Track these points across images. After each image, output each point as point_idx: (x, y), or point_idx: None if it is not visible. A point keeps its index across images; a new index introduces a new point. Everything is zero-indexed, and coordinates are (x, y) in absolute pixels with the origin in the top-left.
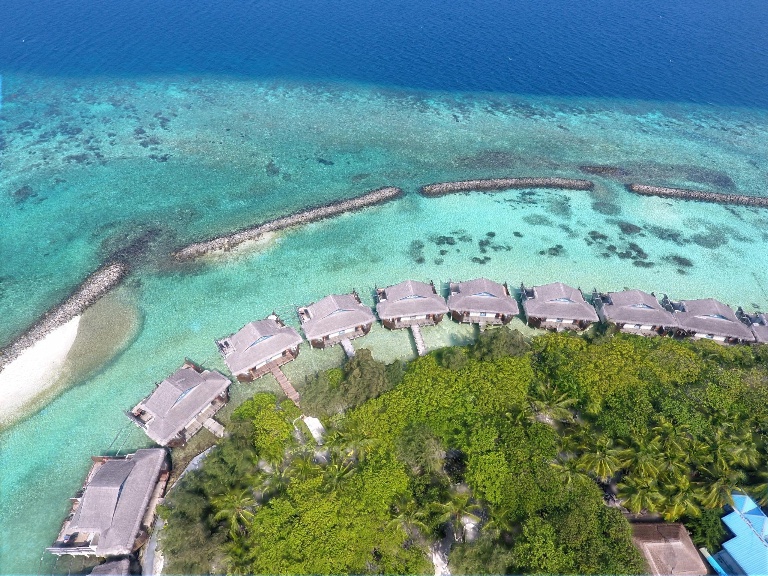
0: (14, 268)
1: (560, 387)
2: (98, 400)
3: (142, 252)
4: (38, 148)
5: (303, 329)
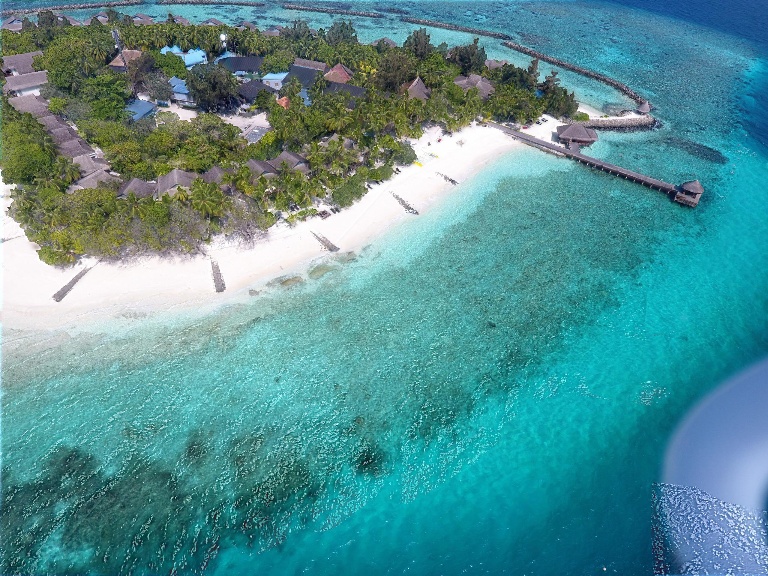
0: None
1: None
2: None
3: None
4: None
5: None
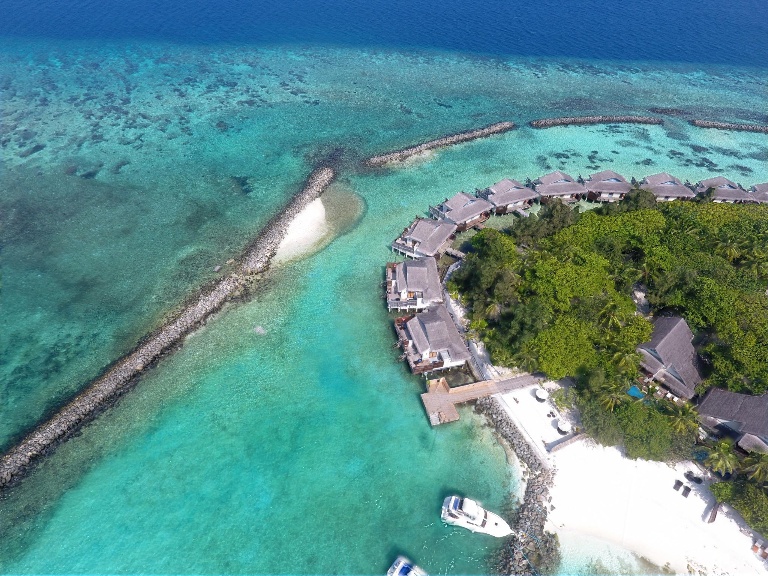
0: (250, 171)
1: (687, 223)
2: (362, 242)
3: (339, 162)
4: (211, 96)
5: (491, 200)
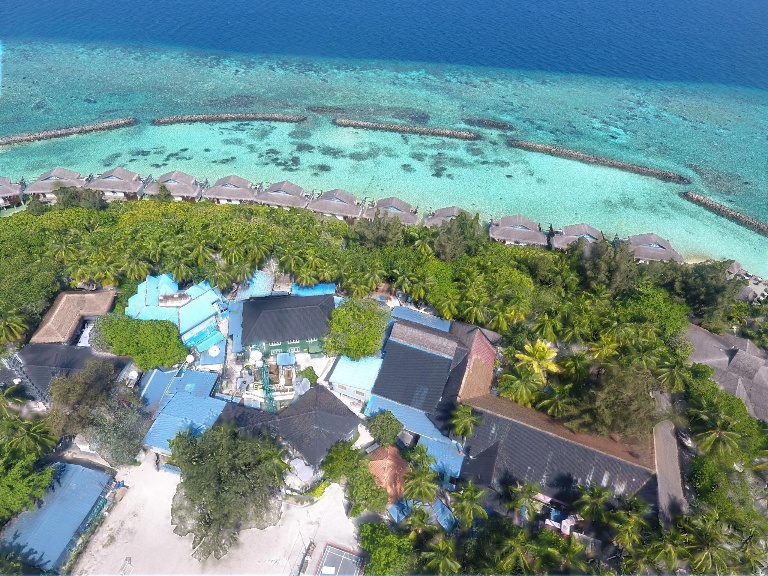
0: None
1: None
2: None
3: None
4: None
5: None
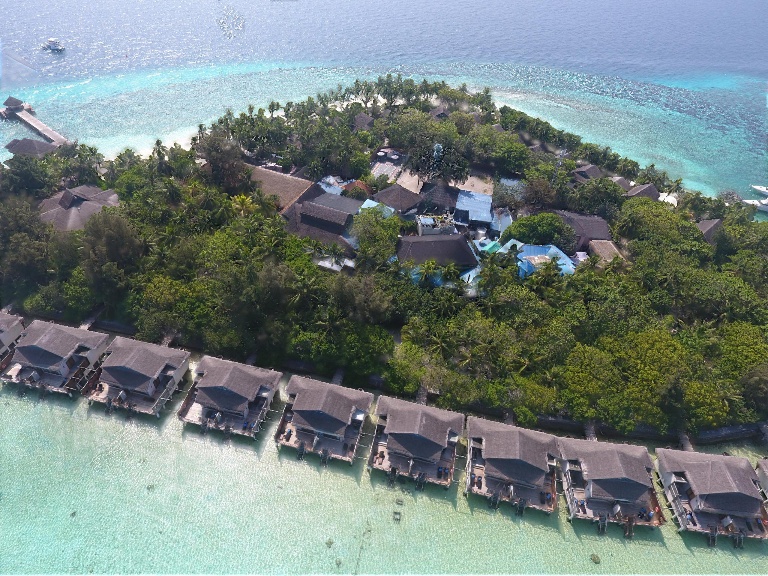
0: None
1: None
2: None
3: None
4: None
5: None
